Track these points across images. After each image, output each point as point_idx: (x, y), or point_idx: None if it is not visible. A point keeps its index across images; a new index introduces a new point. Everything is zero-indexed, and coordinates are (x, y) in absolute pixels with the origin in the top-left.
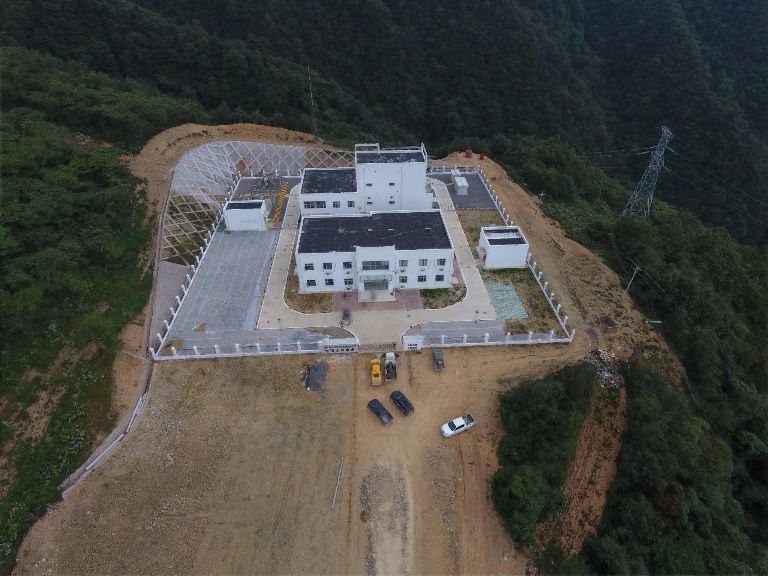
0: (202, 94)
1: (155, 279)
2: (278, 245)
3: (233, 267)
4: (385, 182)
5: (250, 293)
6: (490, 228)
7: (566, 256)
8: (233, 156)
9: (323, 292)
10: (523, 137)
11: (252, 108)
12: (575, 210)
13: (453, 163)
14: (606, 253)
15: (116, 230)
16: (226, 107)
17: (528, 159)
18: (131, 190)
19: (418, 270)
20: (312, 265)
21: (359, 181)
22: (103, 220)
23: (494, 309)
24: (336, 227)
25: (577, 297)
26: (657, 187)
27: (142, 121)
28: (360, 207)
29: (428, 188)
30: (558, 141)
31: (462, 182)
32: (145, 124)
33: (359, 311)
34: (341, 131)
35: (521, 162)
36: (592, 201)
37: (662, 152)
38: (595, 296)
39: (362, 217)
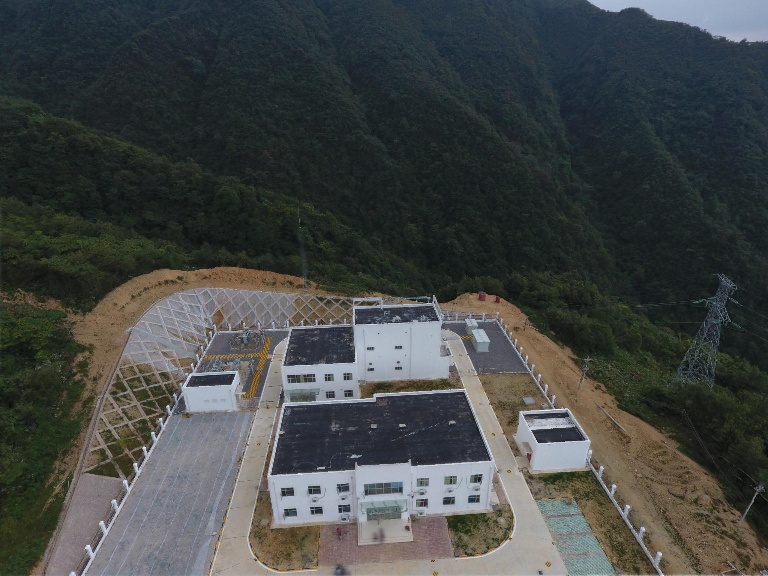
0: (189, 230)
1: (66, 508)
2: (251, 436)
3: (184, 478)
4: (390, 345)
5: (201, 529)
6: (531, 412)
7: (634, 446)
8: (210, 306)
9: (307, 524)
10: (539, 274)
11: (242, 243)
12: (618, 366)
13: (466, 308)
14: (678, 433)
15: (30, 426)
16: (208, 249)
17: (550, 301)
18: (67, 363)
19: (444, 490)
20: (292, 489)
21: (358, 345)
22: (8, 419)
23: (560, 555)
24: (328, 421)
25: (674, 527)
26: (721, 343)
27: (101, 273)
28: (359, 379)
29: (443, 349)
30: (576, 276)
31: (482, 337)
32: (104, 276)
33: (360, 564)
34: (336, 273)
35: (543, 305)
36: (632, 350)
37: (722, 303)
38: (699, 525)
39: (363, 403)
